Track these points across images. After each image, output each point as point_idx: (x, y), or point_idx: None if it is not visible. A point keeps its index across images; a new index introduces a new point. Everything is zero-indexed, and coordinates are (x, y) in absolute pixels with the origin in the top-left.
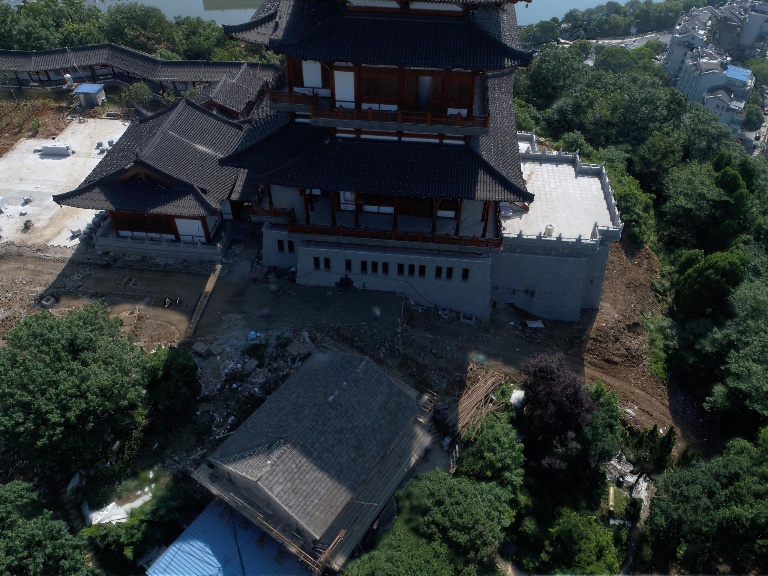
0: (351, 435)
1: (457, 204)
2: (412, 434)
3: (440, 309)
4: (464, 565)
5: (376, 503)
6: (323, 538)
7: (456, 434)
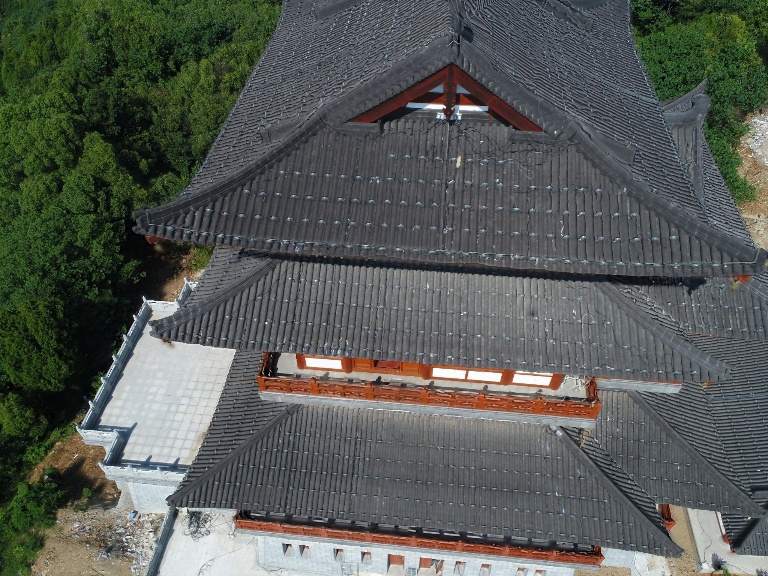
0: None
1: None
2: None
3: None
4: None
5: None
6: None
7: None
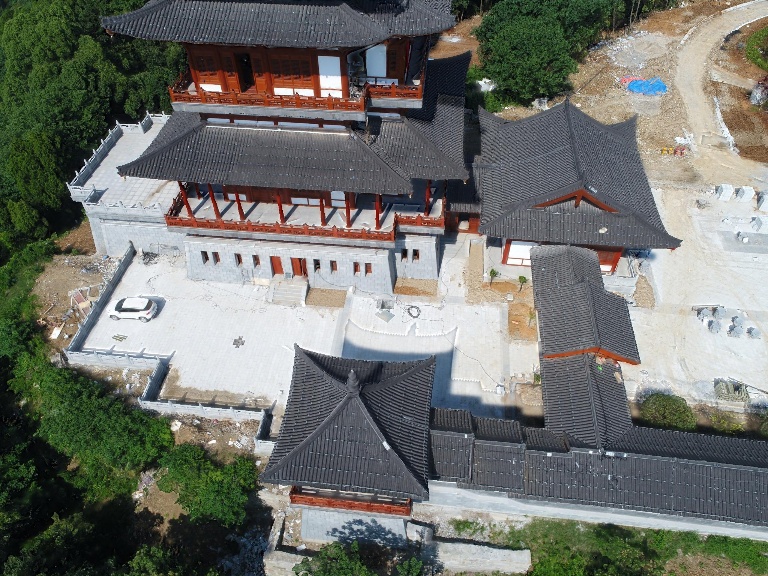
0: None
1: None
2: None
3: None
4: None
5: None
6: None
7: None
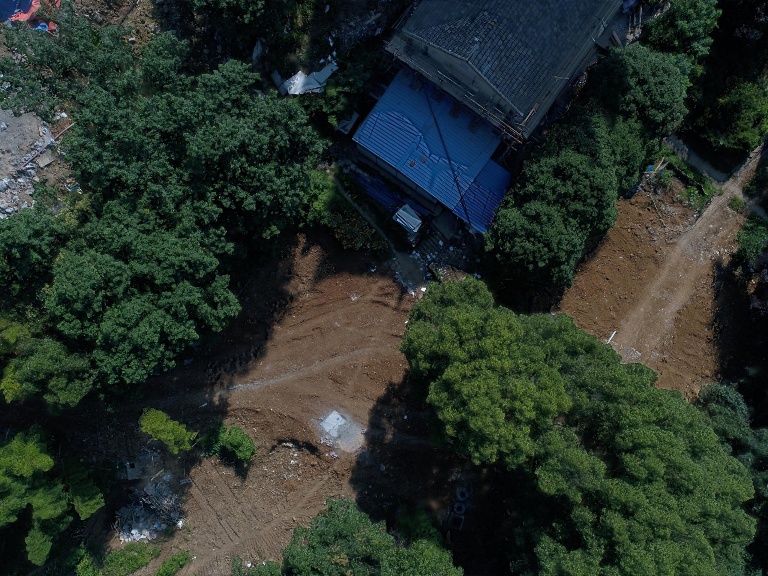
0: (555, 5)
1: None
2: None
3: None
4: (650, 138)
5: (564, 76)
6: None
7: None
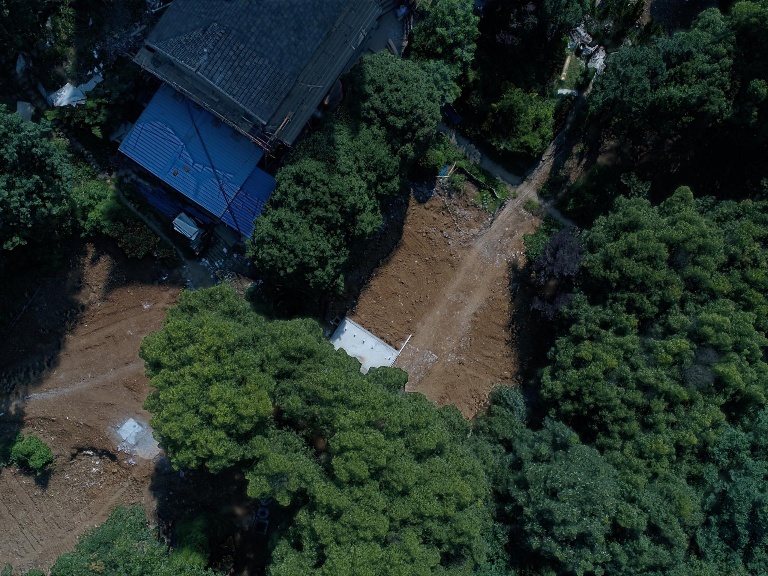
0: (290, 15)
1: None
2: (360, 7)
3: None
4: (401, 144)
5: (323, 84)
6: (273, 119)
7: (411, 3)
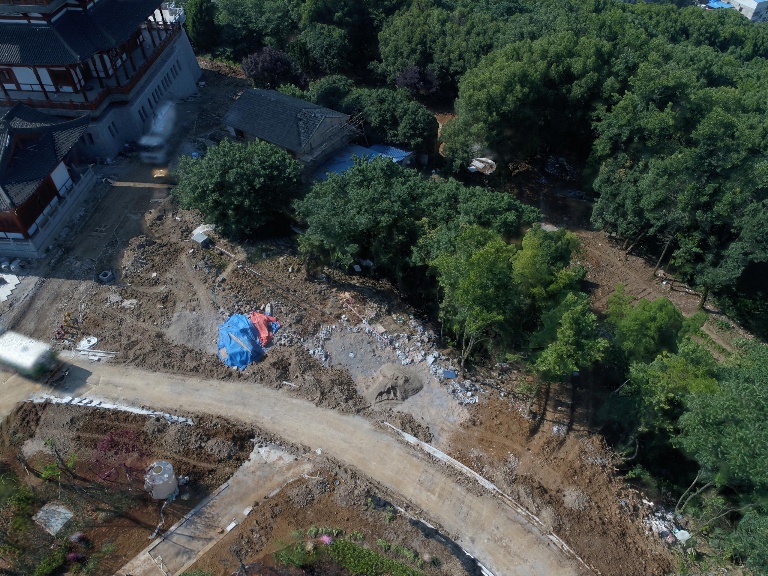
0: None
1: (139, 28)
2: None
3: (186, 100)
4: None
5: None
6: None
7: None
